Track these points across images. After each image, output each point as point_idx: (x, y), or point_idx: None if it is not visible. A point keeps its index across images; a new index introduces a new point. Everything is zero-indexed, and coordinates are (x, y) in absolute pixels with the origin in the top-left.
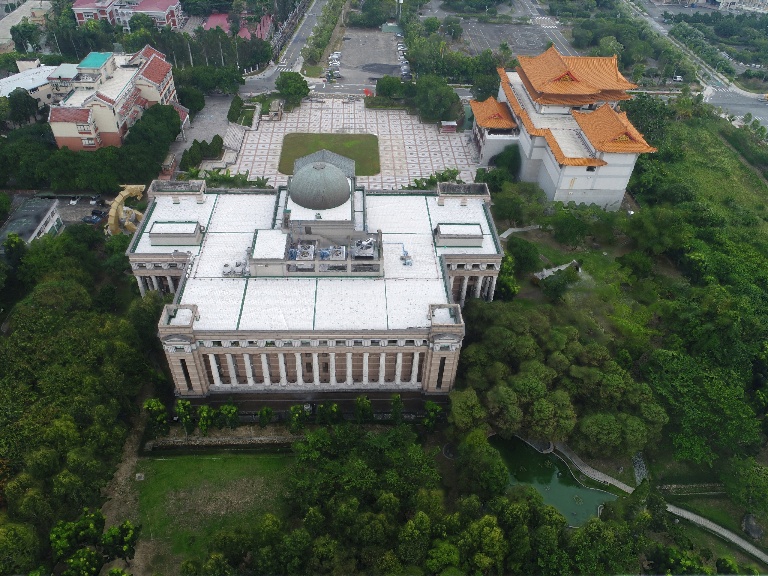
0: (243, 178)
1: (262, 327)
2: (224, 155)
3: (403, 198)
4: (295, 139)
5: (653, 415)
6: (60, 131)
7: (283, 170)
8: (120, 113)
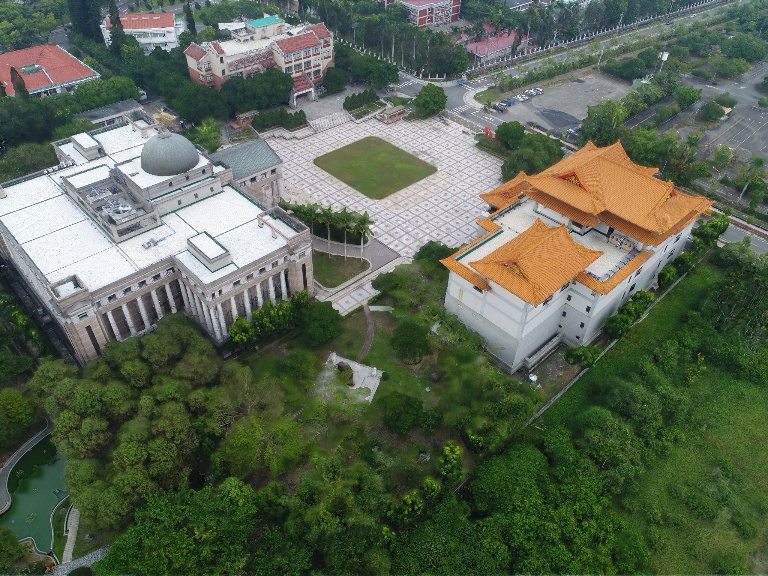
0: (203, 137)
1: (11, 223)
2: (301, 130)
3: (249, 205)
4: (370, 142)
5: (101, 503)
6: (190, 63)
7: (318, 160)
8: (229, 63)
